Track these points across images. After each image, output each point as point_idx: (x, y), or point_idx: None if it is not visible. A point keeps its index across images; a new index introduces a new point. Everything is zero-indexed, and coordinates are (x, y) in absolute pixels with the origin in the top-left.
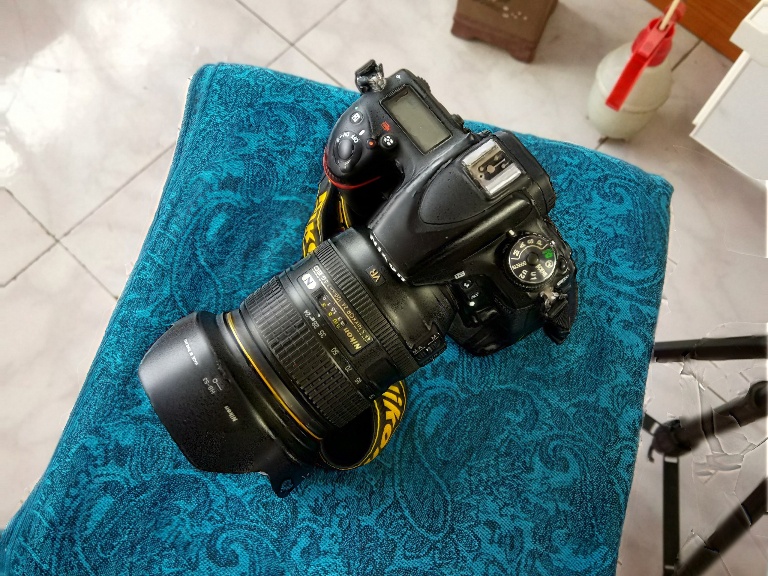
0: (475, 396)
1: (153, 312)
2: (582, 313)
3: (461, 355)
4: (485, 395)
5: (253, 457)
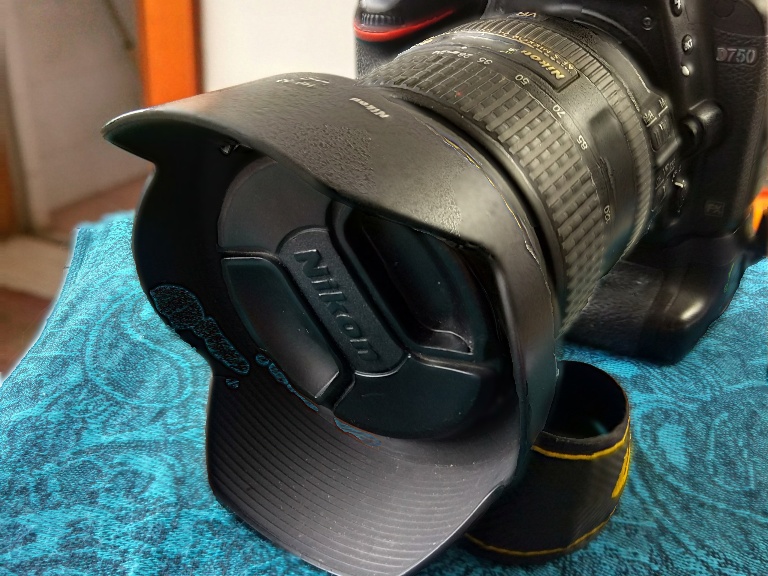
0: (708, 403)
1: (51, 405)
2: (761, 304)
3: (640, 367)
4: (722, 399)
5: (454, 197)
